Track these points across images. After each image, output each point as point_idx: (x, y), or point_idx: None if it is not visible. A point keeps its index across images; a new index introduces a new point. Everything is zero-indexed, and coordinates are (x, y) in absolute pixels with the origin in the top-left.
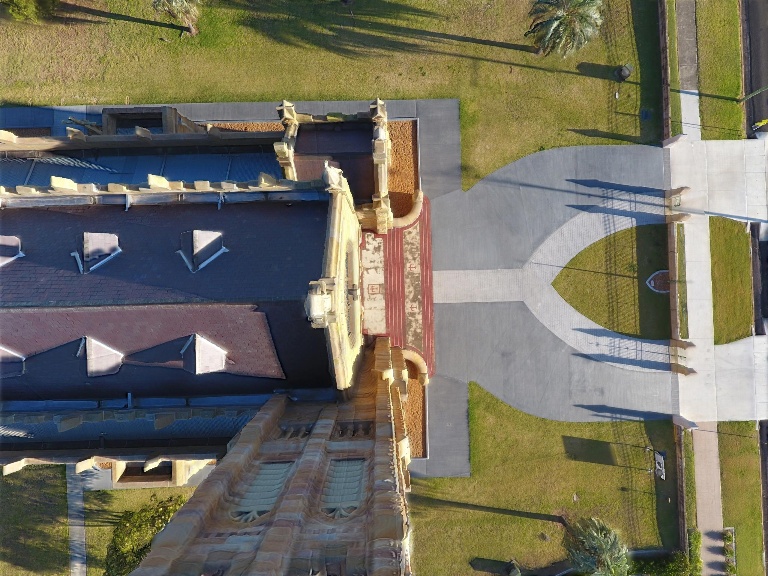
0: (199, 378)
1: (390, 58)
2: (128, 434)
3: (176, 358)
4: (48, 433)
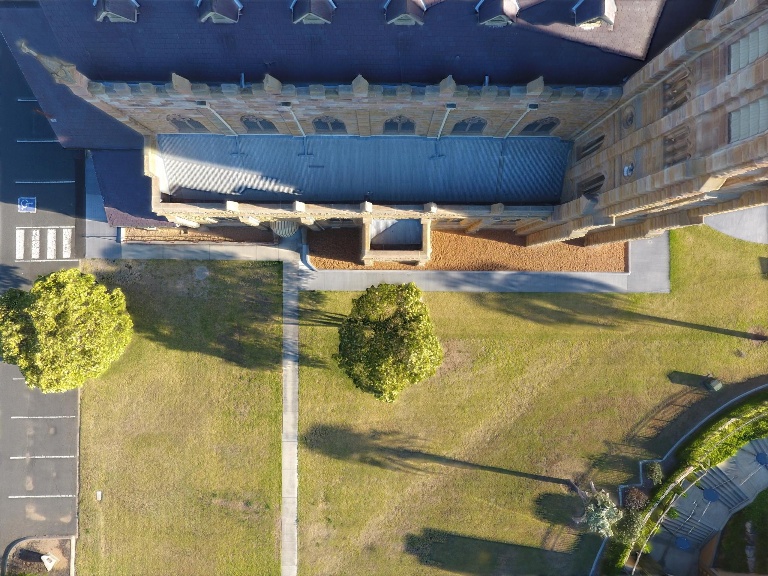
0: (565, 55)
1: None
2: (393, 194)
3: (564, 18)
4: (317, 190)
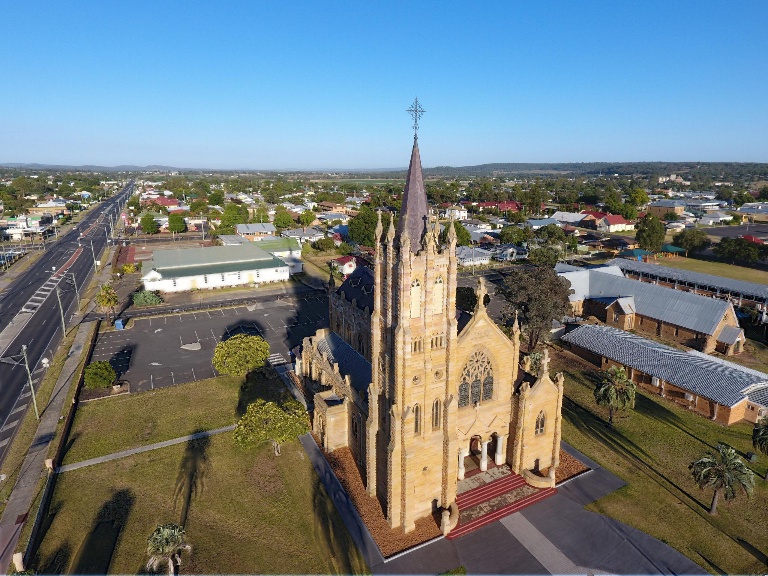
0: None
1: (606, 450)
2: None
3: None
4: None
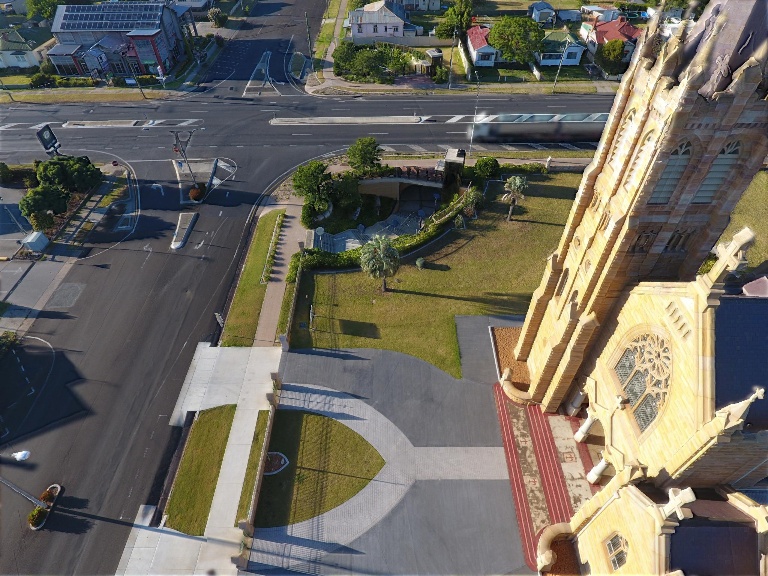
0: None
1: None
2: None
3: None
4: None
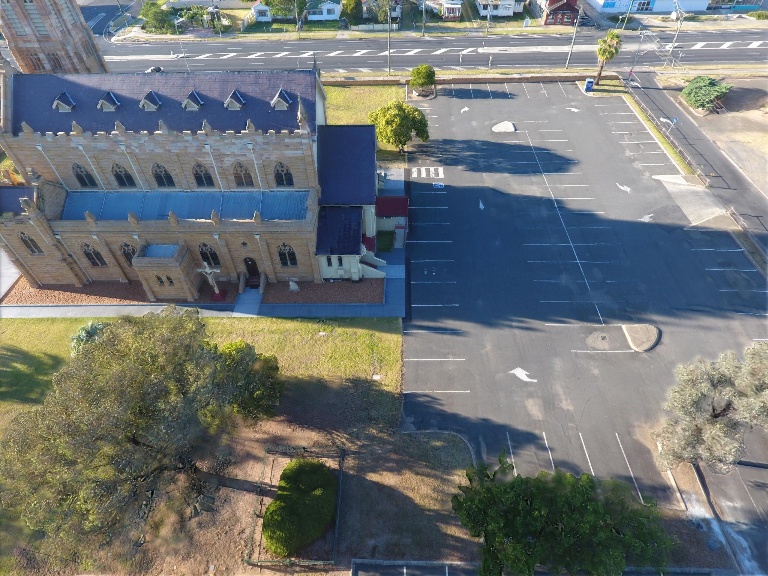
0: None
1: None
2: None
3: None
4: None
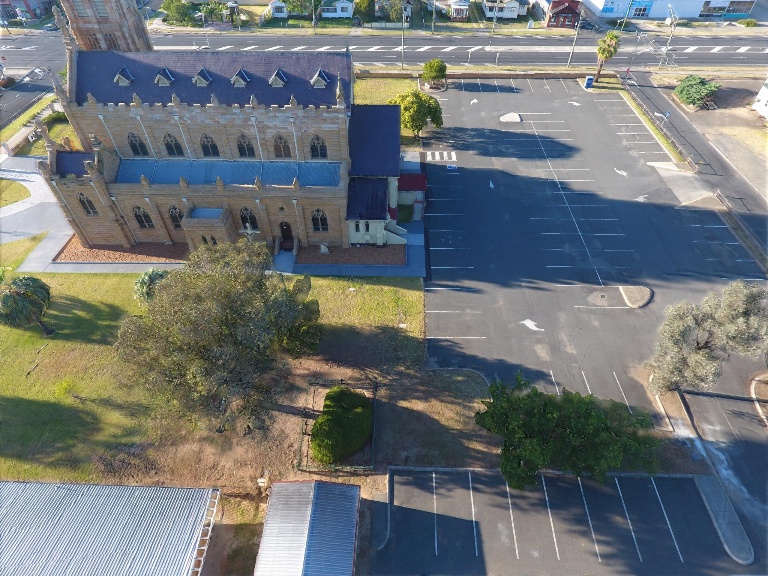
0: None
1: None
2: None
3: None
4: None
